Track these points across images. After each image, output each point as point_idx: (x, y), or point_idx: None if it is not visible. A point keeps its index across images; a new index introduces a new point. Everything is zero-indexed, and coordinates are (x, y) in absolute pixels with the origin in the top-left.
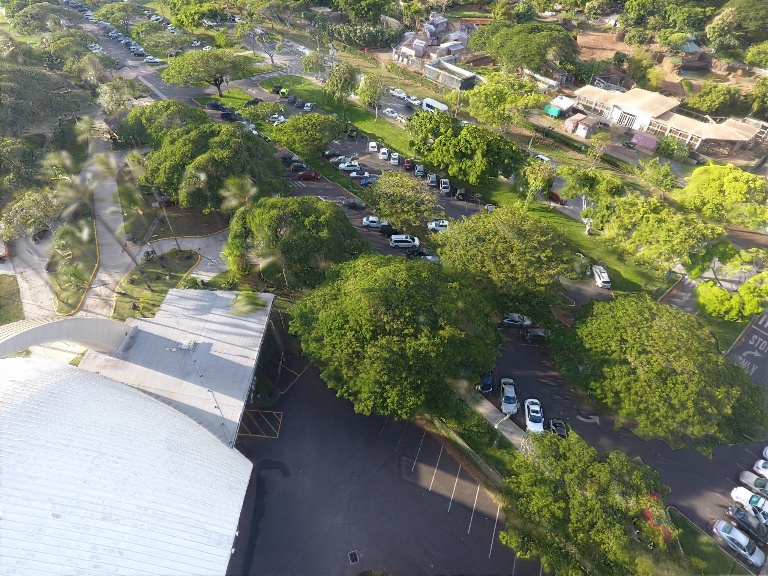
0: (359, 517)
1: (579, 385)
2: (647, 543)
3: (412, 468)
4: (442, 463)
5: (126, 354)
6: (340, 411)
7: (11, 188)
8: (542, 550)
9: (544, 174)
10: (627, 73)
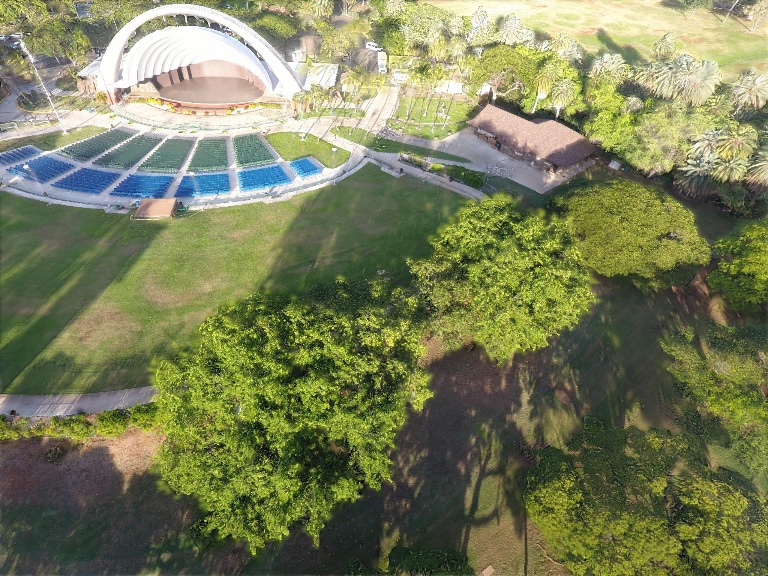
0: None
1: None
2: None
3: None
4: None
5: (121, 77)
6: None
7: None
8: None
9: None
10: None
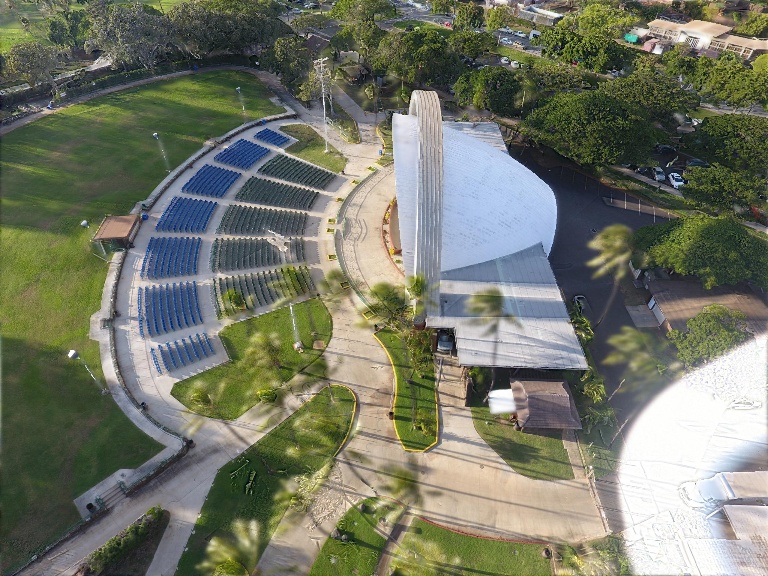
0: (589, 218)
1: (708, 155)
2: (766, 199)
3: (611, 201)
4: (628, 199)
5: None
6: (555, 181)
7: (296, 70)
8: (710, 205)
9: (651, 62)
10: (684, 13)
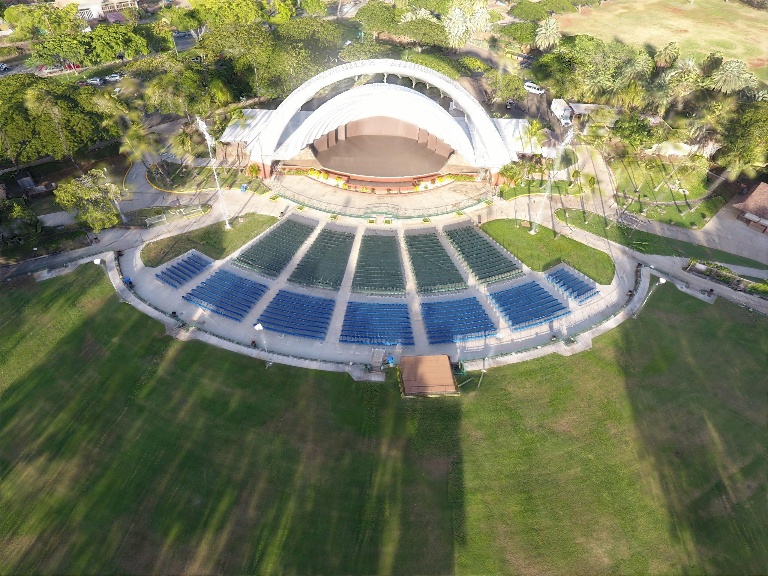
0: None
1: (317, 50)
2: None
3: None
4: None
5: (278, 144)
6: None
7: None
8: None
9: (167, 26)
10: None
